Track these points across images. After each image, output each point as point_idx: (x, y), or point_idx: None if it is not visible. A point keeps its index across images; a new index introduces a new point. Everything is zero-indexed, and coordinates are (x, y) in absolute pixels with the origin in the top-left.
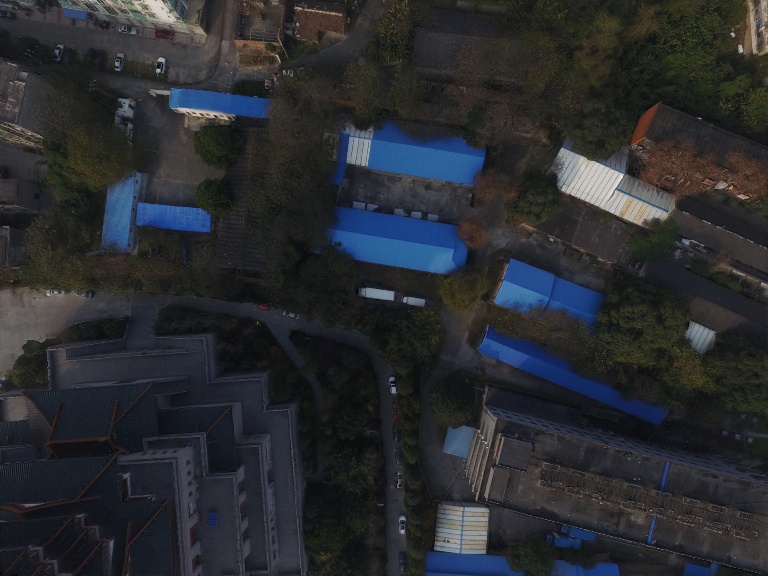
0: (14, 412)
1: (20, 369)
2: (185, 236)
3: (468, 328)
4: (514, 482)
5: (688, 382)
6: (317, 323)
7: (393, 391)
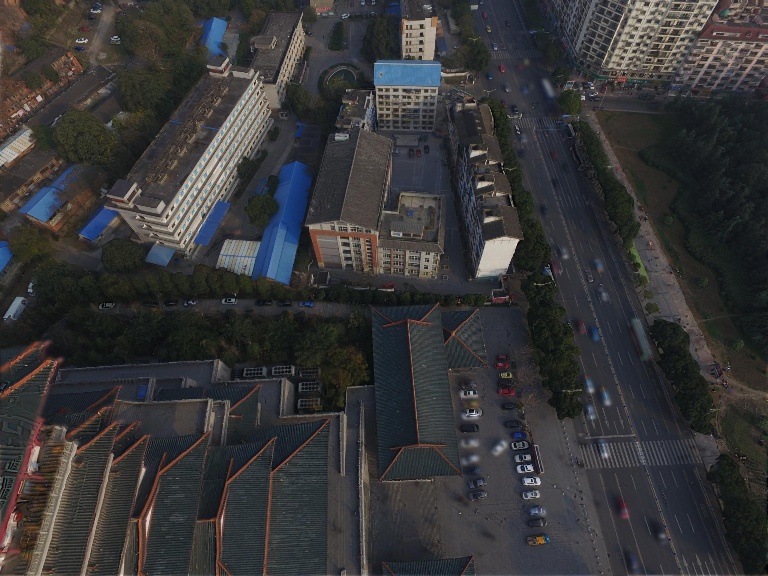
0: None
1: None
2: None
3: (79, 251)
4: (156, 197)
5: (137, 119)
6: None
7: (110, 305)
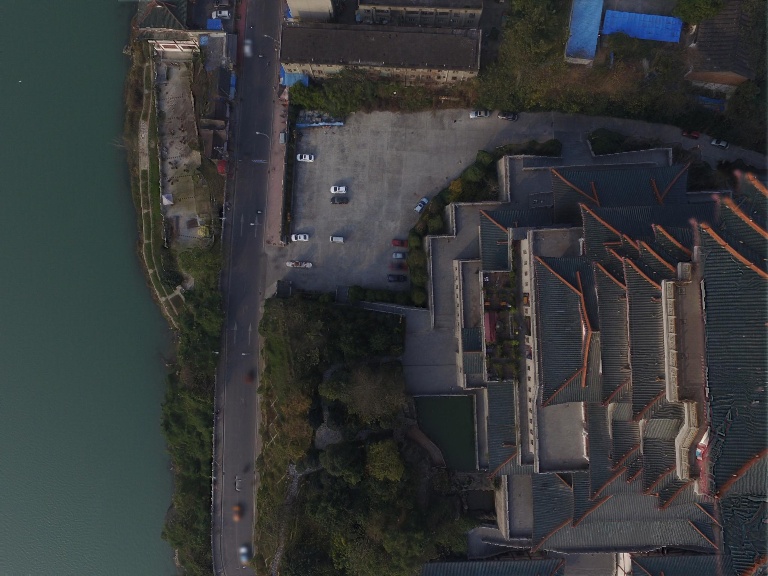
0: (468, 220)
1: (479, 175)
2: (655, 44)
3: None
4: None
5: None
6: (743, 155)
7: None
